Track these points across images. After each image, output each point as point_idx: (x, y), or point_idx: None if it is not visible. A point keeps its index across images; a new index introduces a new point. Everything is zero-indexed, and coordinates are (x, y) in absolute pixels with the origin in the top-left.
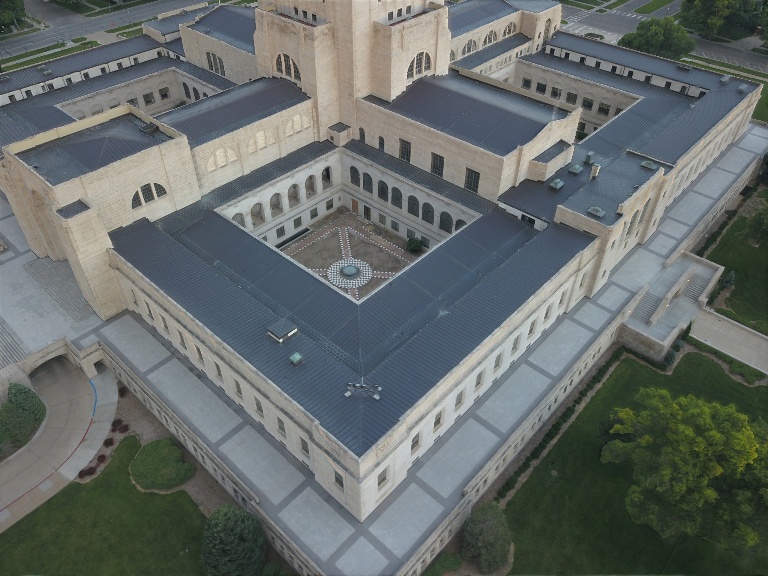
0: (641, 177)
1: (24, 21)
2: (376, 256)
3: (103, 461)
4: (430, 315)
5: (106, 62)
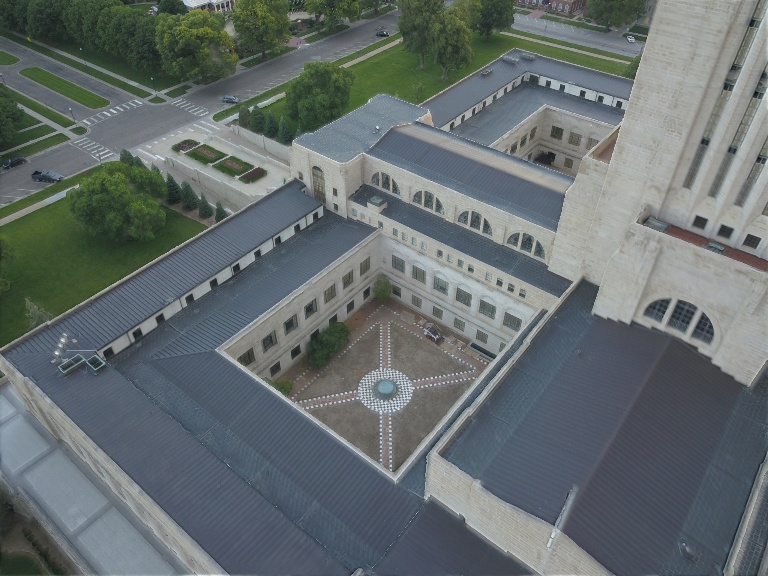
0: None
1: None
2: None
3: None
4: None
5: None
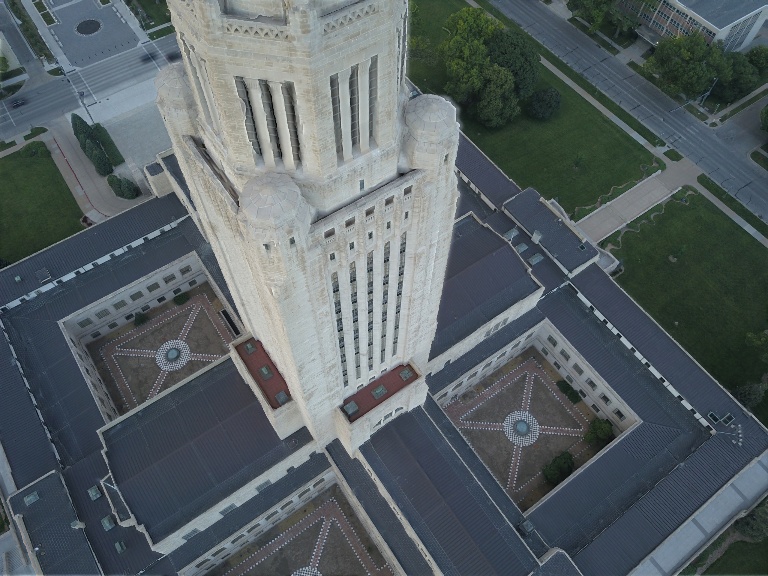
0: (59, 574)
1: (726, 104)
2: (185, 377)
3: (88, 225)
4: (35, 363)
5: (463, 171)
